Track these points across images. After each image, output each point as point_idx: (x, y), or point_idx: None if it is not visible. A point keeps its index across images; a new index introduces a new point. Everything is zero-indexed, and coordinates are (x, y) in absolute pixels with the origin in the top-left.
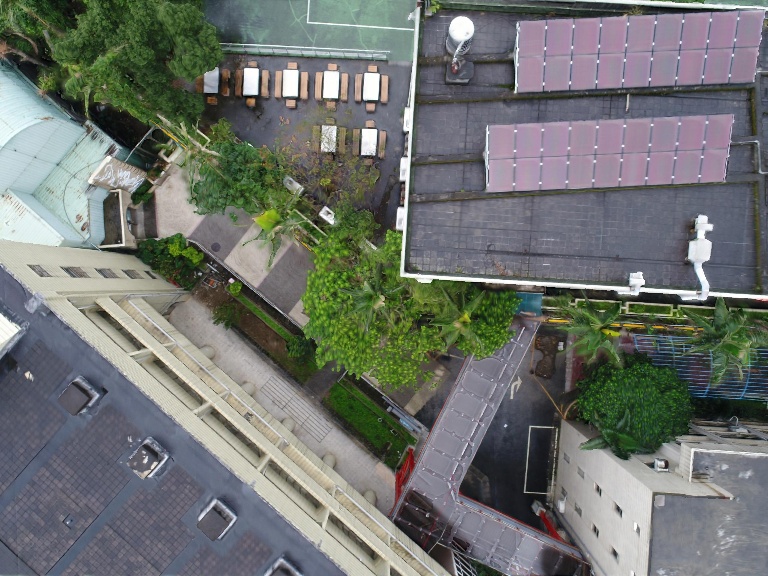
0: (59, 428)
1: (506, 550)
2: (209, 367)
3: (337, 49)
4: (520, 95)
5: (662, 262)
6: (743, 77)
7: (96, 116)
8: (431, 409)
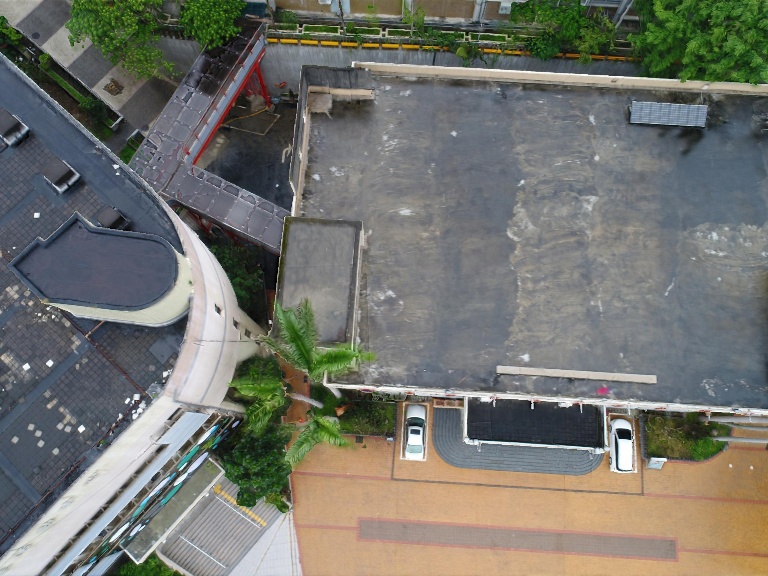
0: None
1: None
2: None
3: None
4: None
5: None
6: None
7: None
8: None
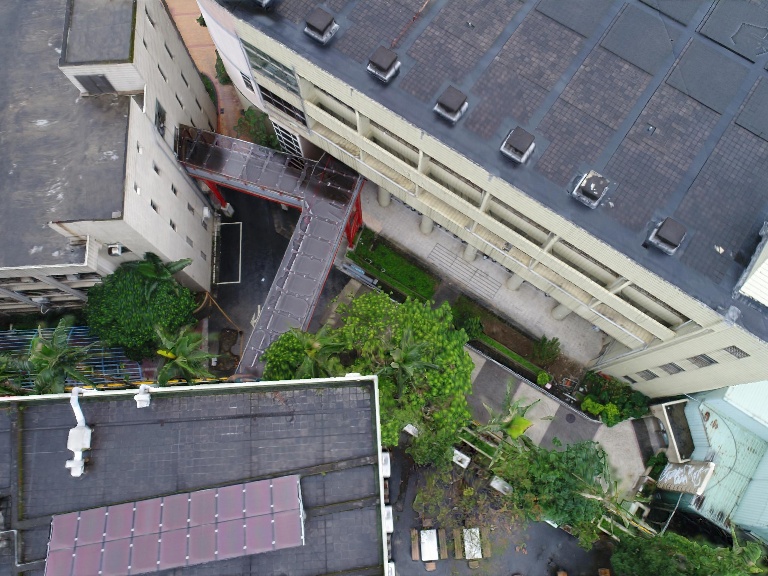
0: (679, 206)
1: (255, 166)
2: (553, 290)
3: None
4: None
5: (117, 424)
6: None
7: (726, 545)
8: (336, 287)
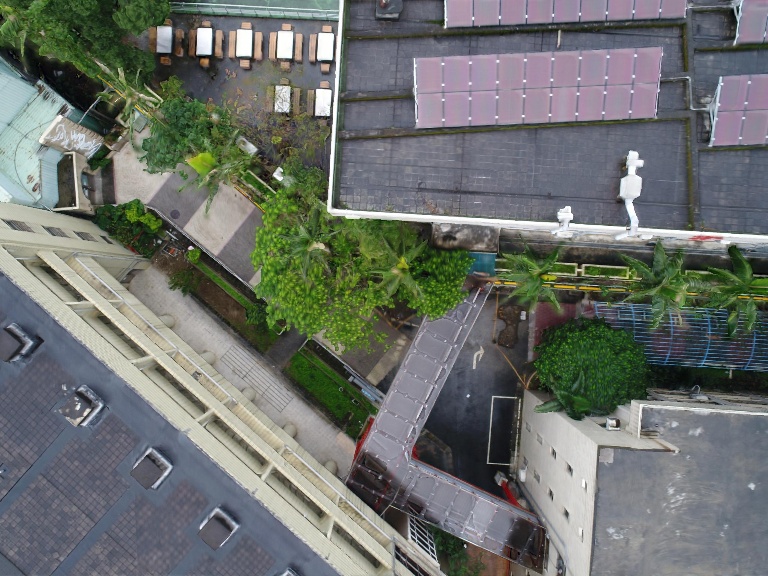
0: None
1: (463, 516)
2: (158, 326)
3: (291, 8)
4: (450, 30)
5: (594, 200)
6: (674, 12)
7: (53, 81)
8: None
